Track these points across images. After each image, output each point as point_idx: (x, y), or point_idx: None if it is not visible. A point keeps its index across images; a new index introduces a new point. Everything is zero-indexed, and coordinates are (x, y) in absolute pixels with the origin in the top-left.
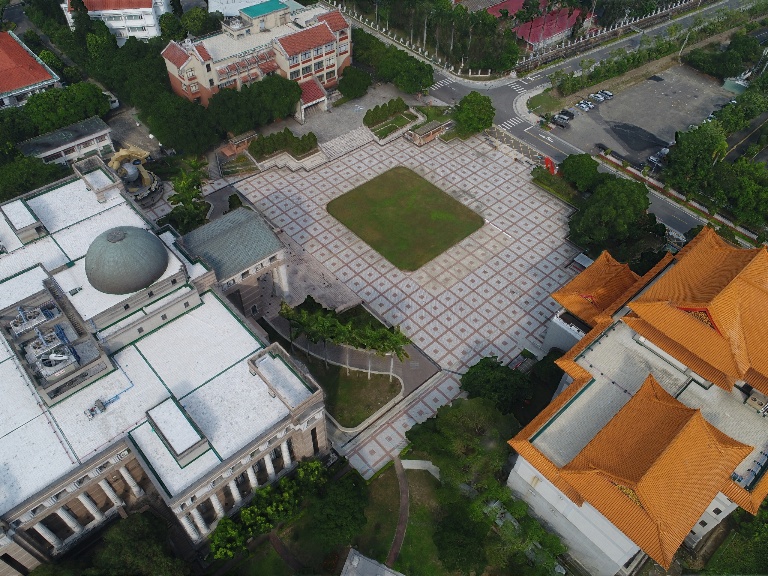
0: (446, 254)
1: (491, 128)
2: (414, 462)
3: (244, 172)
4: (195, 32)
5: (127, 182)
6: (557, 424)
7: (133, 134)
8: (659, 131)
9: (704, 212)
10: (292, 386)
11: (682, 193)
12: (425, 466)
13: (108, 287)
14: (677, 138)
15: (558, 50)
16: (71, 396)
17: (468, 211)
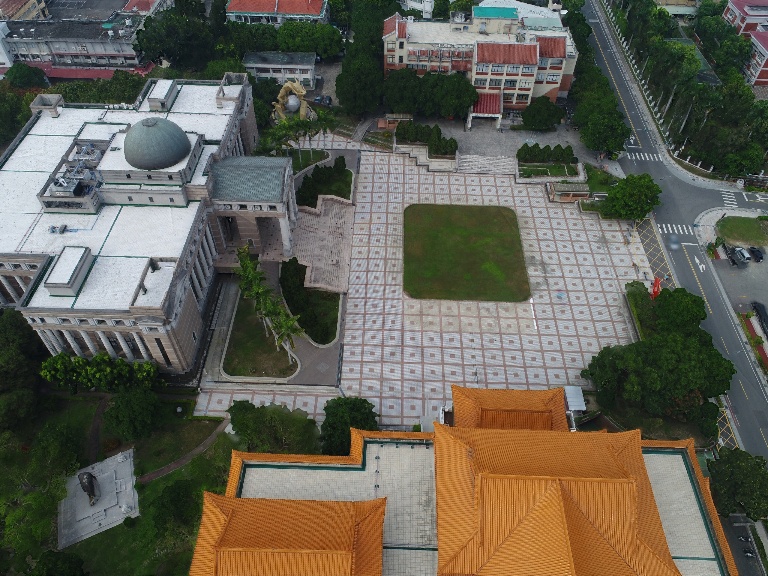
0: (457, 303)
1: (646, 222)
2: None
3: (379, 146)
4: None
5: None
6: (286, 473)
7: None
8: None
9: None
10: (162, 296)
11: None
12: None
13: (126, 156)
14: None
15: None
16: (60, 214)
17: (524, 281)
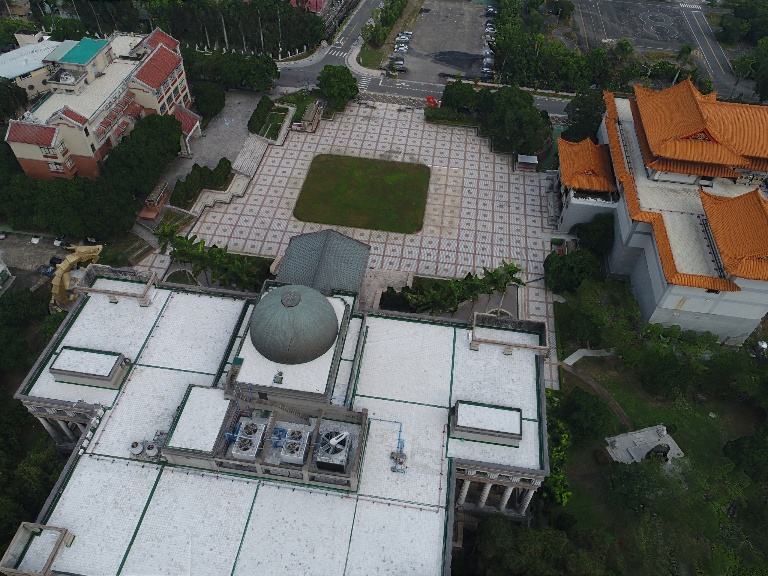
0: (429, 204)
1: None
2: (572, 357)
3: (183, 226)
4: None
5: None
6: (675, 254)
7: (7, 249)
8: (467, 48)
9: (548, 93)
10: (512, 339)
11: (525, 86)
12: (581, 354)
13: (313, 353)
14: (492, 47)
15: None
16: (361, 470)
17: (408, 165)
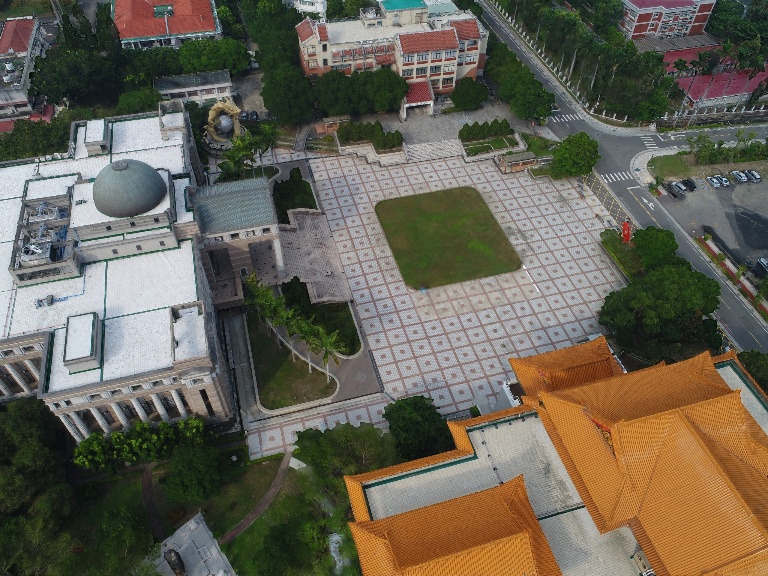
0: (460, 285)
1: (591, 176)
2: (301, 464)
3: (325, 151)
4: (351, 15)
5: (222, 132)
6: (405, 483)
7: (257, 93)
8: None
9: None
10: (196, 344)
11: None
12: None
13: (100, 206)
14: None
15: (725, 114)
16: (38, 285)
17: (511, 251)
